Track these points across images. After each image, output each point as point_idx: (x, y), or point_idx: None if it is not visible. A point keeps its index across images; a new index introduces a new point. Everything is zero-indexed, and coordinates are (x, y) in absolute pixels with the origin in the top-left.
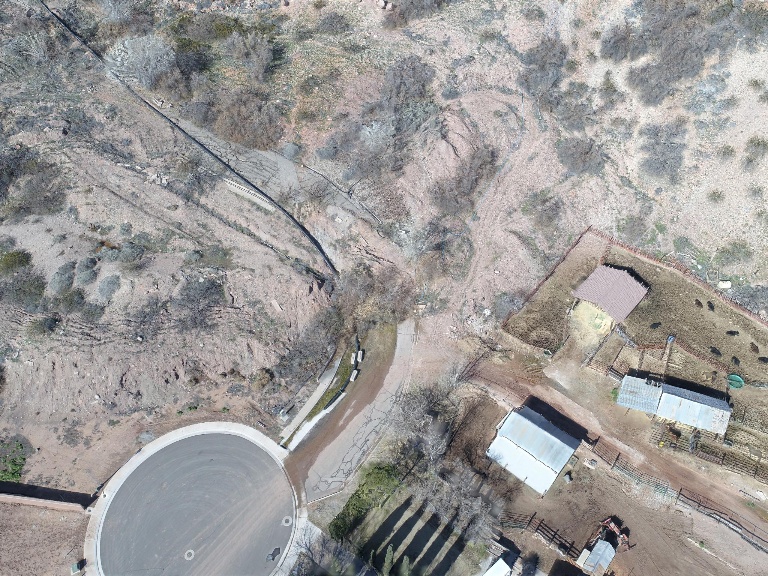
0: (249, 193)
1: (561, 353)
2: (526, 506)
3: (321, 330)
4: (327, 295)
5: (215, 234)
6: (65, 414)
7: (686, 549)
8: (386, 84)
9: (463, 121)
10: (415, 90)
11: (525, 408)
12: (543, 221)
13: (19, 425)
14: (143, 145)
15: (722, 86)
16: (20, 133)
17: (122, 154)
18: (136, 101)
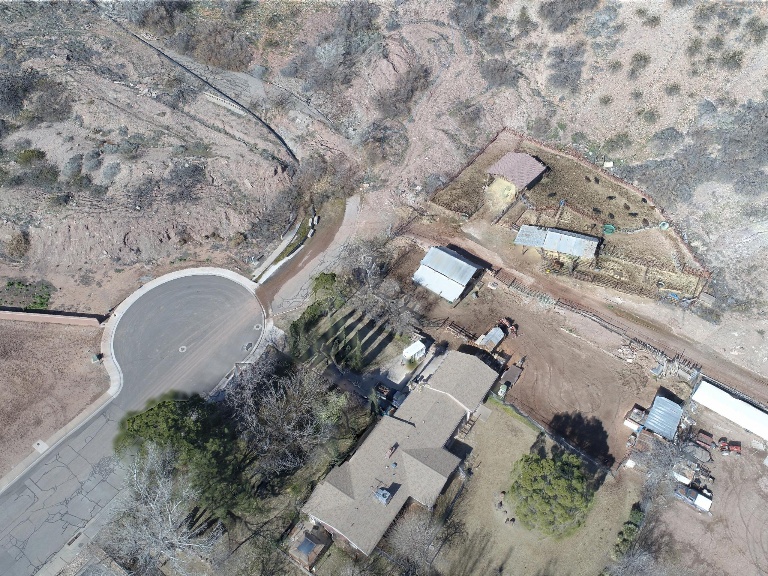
0: (224, 102)
1: (476, 216)
2: (441, 313)
3: (285, 204)
4: (289, 177)
5: (197, 134)
6: (80, 266)
7: (559, 335)
8: (339, 19)
9: (402, 45)
10: (363, 23)
11: (443, 247)
12: (466, 122)
13: (43, 274)
14: (135, 68)
15: (615, 15)
16: (30, 59)
17: (117, 75)
18: (127, 35)
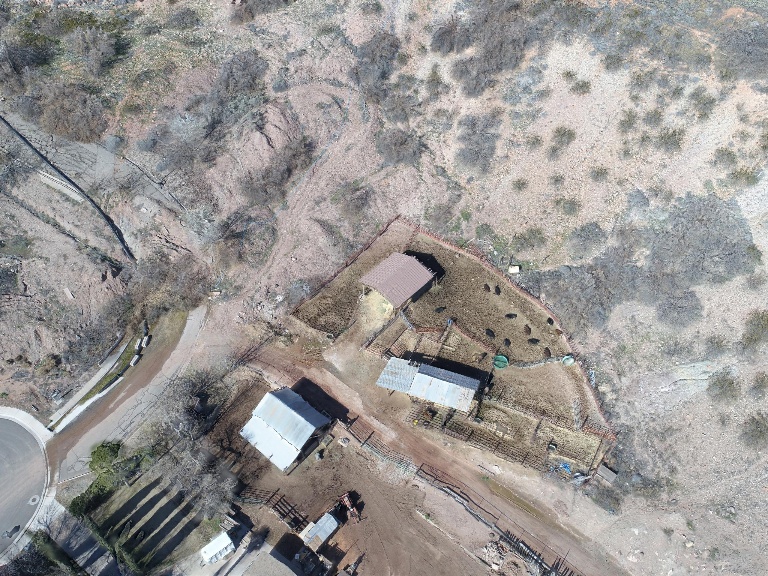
0: (61, 184)
1: (344, 337)
2: (271, 483)
3: (114, 317)
4: (123, 283)
5: (22, 225)
6: None
7: (413, 521)
8: None
9: (283, 113)
10: (243, 83)
11: (285, 389)
12: (350, 210)
13: None
14: None
15: (539, 77)
16: None
17: None
18: None
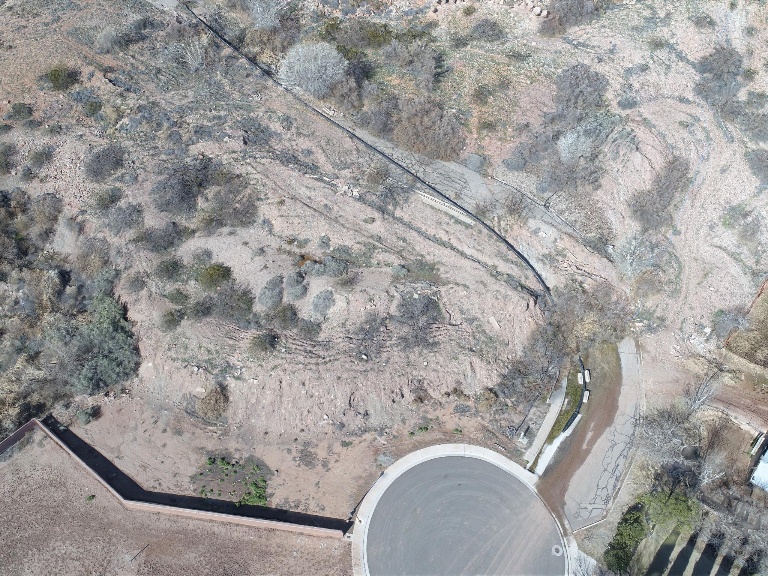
0: (445, 206)
1: None
2: None
3: (539, 348)
4: (541, 312)
5: (416, 248)
6: (294, 434)
7: None
8: (559, 93)
9: (651, 132)
10: (593, 99)
11: None
12: (747, 236)
13: (250, 445)
14: (326, 155)
15: None
16: (201, 143)
17: (306, 165)
18: (307, 110)
